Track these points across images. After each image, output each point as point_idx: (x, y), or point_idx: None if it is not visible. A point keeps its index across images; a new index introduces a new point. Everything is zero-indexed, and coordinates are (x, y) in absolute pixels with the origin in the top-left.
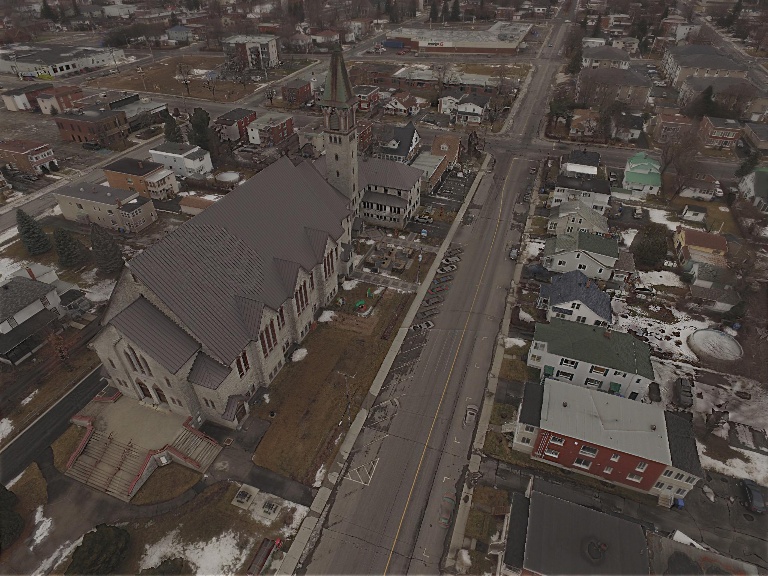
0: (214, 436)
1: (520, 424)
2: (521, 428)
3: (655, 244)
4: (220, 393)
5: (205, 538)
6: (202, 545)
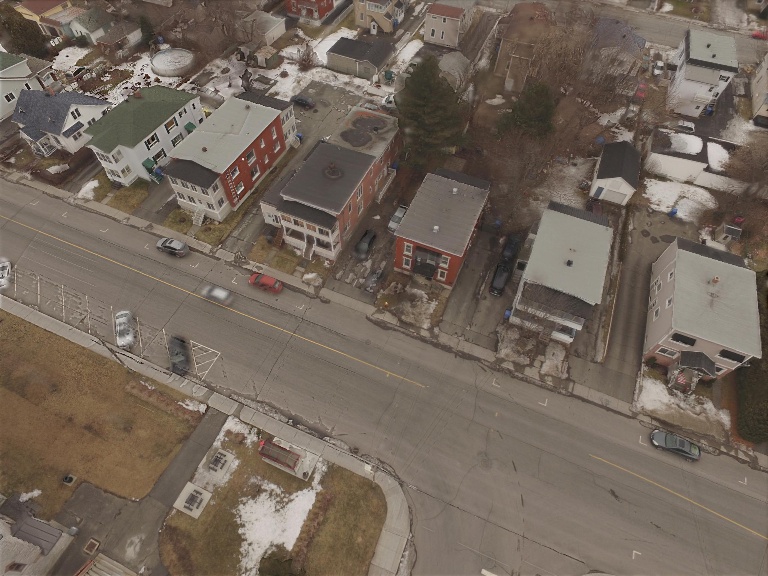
0: (71, 575)
1: (207, 194)
2: (212, 195)
3: (24, 29)
4: (5, 541)
5: (236, 545)
6: (245, 546)
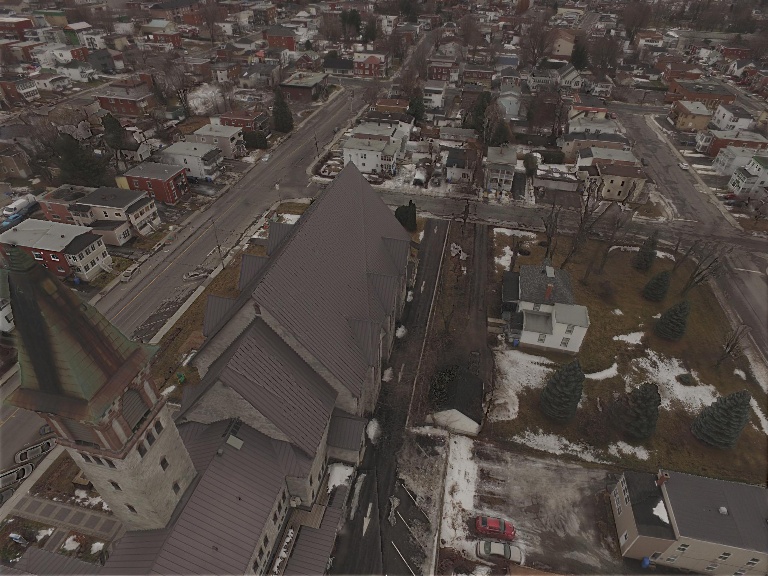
0: None
1: None
2: None
3: None
4: None
5: None
6: None
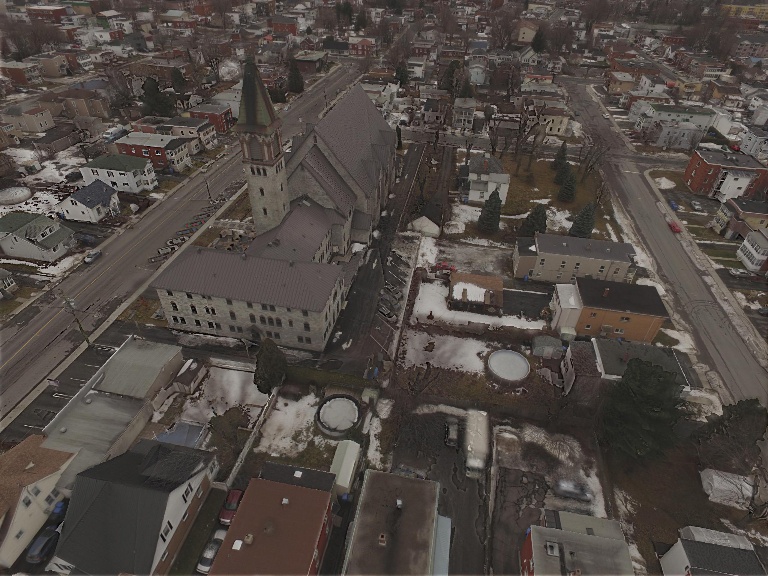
0: None
1: None
2: None
3: None
4: None
5: None
6: None
